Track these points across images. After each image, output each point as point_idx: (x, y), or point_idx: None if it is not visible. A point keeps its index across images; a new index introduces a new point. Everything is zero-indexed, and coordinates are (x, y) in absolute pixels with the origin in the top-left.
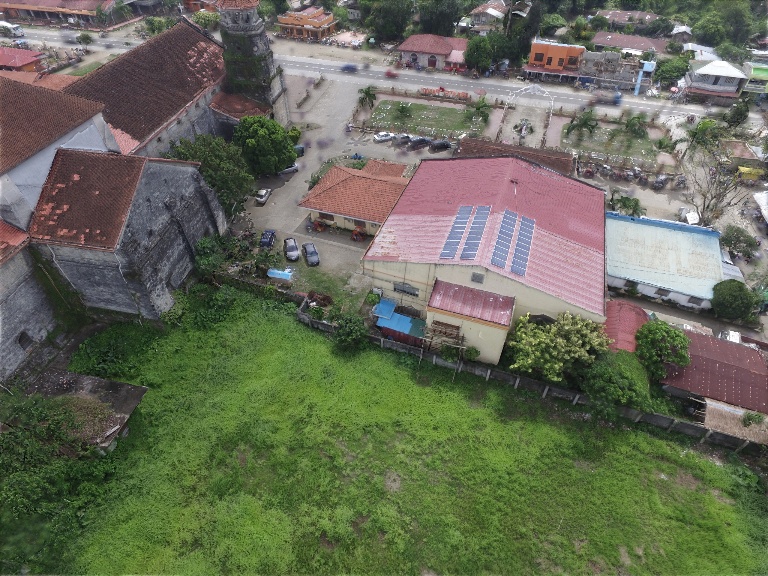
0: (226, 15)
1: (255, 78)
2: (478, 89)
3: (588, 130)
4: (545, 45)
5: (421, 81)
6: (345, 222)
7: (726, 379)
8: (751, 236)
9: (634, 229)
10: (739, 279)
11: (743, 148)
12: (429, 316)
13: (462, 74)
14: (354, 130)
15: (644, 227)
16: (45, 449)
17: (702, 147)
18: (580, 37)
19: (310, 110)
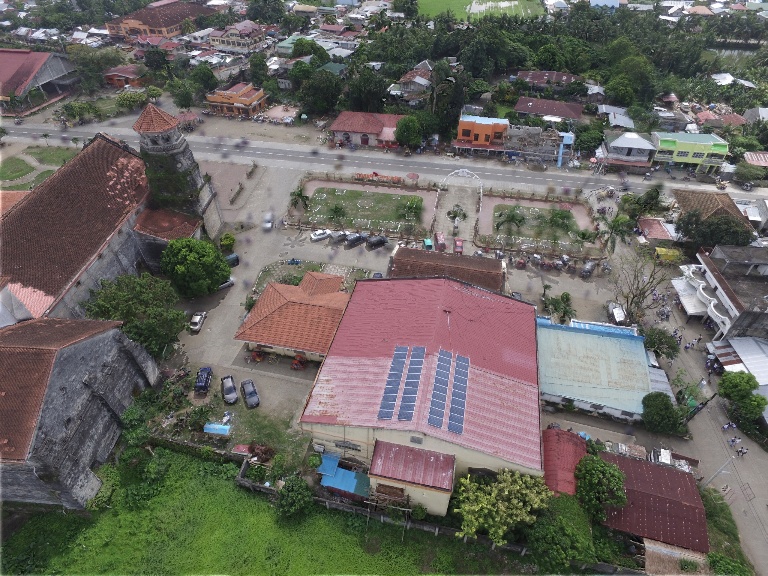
0: (145, 136)
1: (181, 193)
2: (411, 169)
3: (516, 225)
4: (471, 122)
5: (355, 162)
6: (284, 350)
7: (661, 515)
8: (672, 335)
9: (566, 338)
10: (665, 385)
11: (658, 226)
12: (372, 480)
13: (395, 151)
14: (290, 228)
15: (575, 335)
16: None
17: (621, 238)
18: (504, 100)
19: (244, 206)
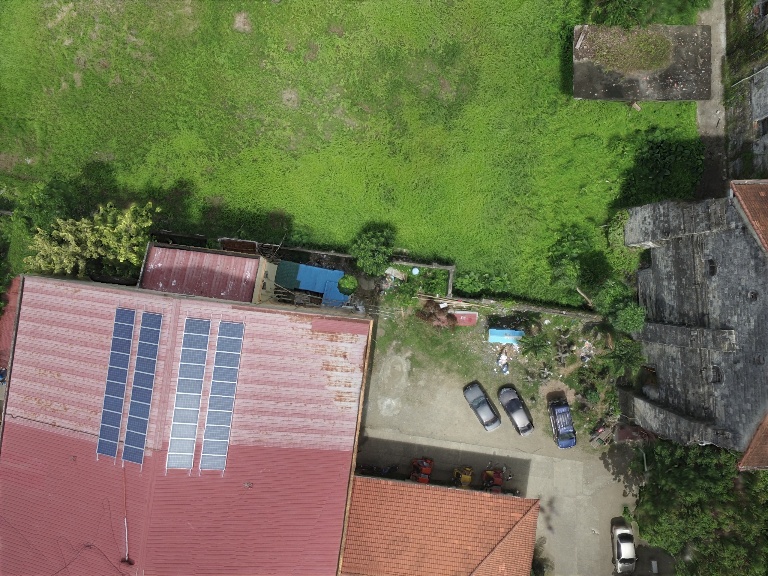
0: None
1: None
2: None
3: None
4: None
5: None
6: None
7: None
8: None
9: None
10: None
11: None
12: None
13: None
14: None
15: None
16: None
17: None
18: None
19: None
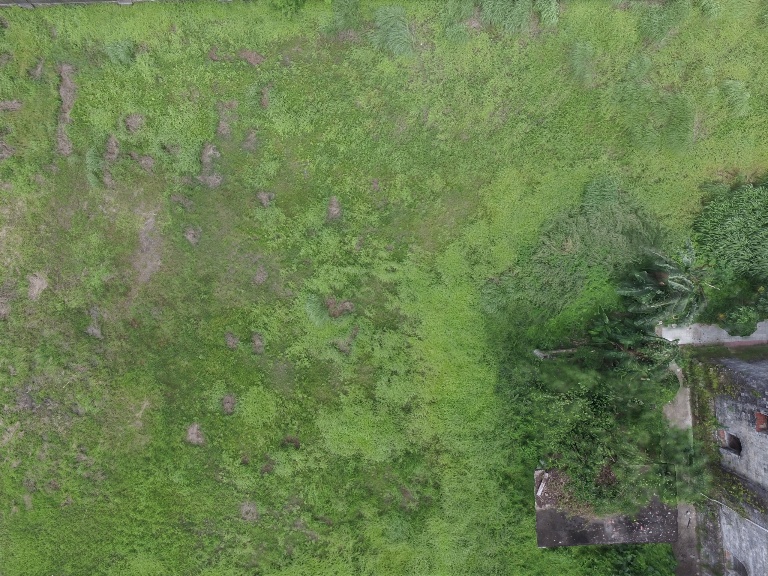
0: None
1: None
2: None
3: None
4: None
5: None
6: None
7: None
8: None
9: None
10: None
11: None
12: None
13: None
14: None
15: None
16: (572, 456)
17: None
18: None
19: None
